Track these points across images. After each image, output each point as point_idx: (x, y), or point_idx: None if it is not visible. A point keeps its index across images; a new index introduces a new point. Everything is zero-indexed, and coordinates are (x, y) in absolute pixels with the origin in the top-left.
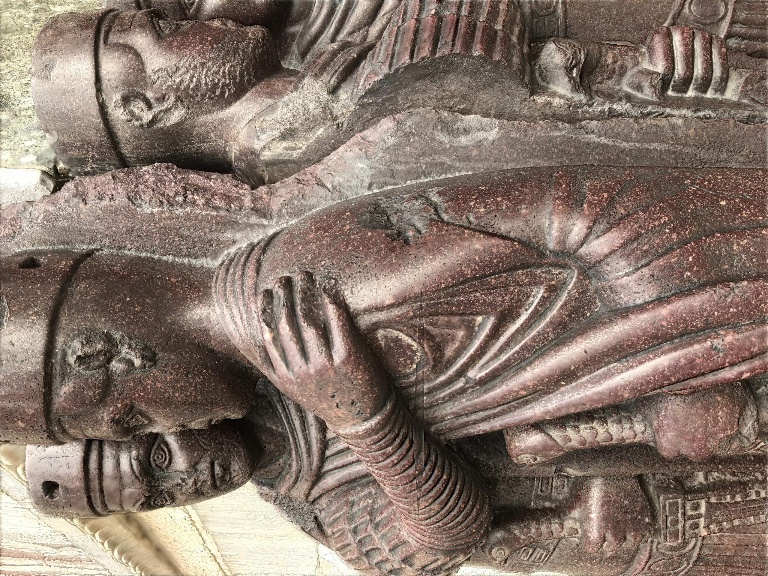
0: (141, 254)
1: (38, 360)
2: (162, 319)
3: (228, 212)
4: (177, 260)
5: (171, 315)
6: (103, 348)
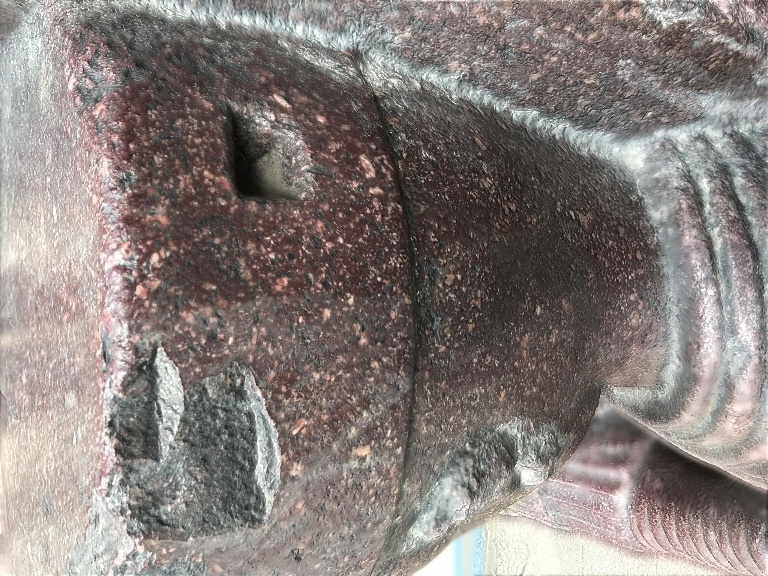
0: (470, 94)
1: (360, 571)
2: (580, 352)
3: (764, 52)
4: (540, 126)
5: (592, 336)
6: (504, 483)
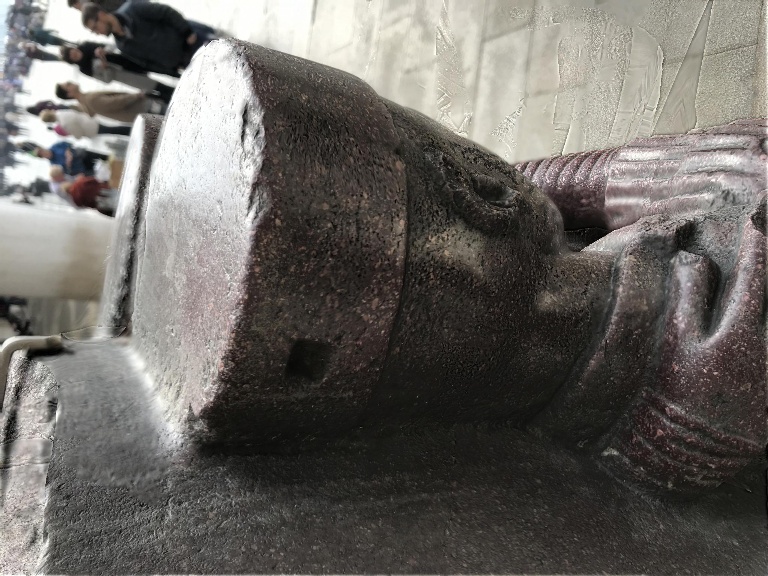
0: None
1: None
2: None
3: None
4: None
5: None
6: None
